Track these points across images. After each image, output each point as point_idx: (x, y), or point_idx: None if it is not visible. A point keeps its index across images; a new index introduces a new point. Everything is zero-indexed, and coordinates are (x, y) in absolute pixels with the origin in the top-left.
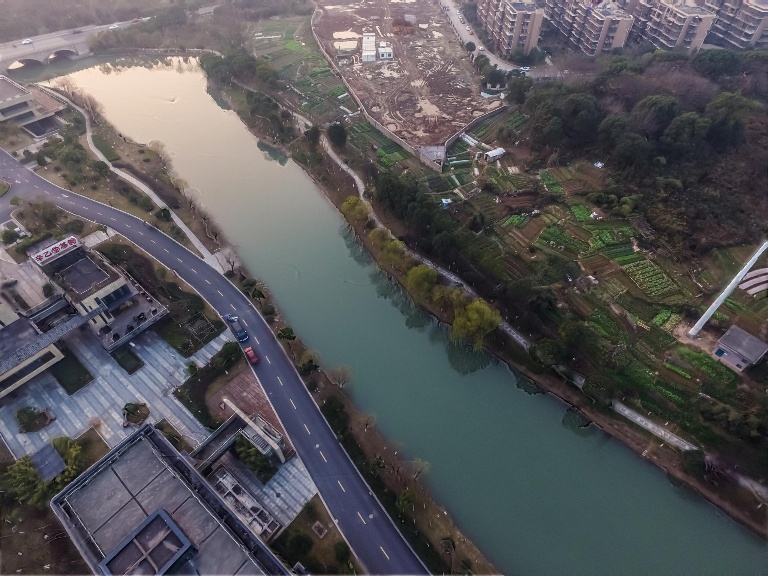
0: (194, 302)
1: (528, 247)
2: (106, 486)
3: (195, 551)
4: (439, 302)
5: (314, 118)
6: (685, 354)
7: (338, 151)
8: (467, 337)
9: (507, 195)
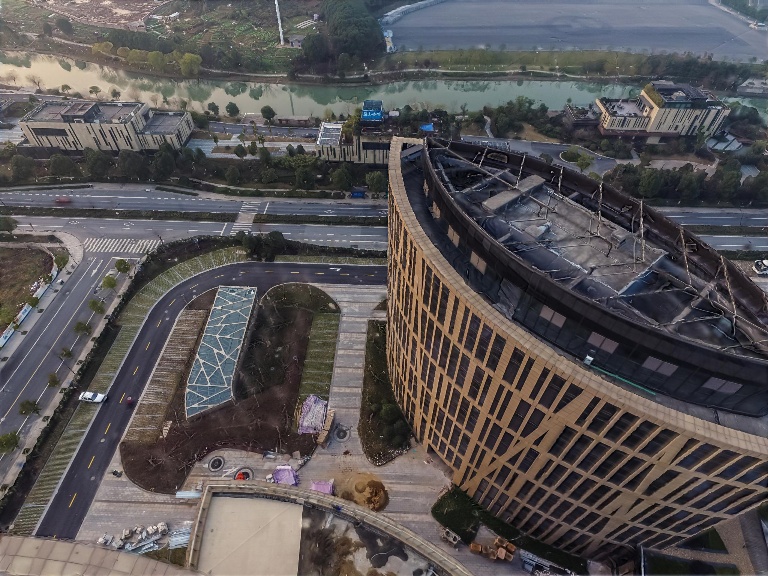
0: (25, 102)
1: (208, 43)
2: (42, 115)
3: (99, 110)
4: (172, 71)
5: (37, 31)
6: (281, 50)
7: (70, 39)
8: (189, 69)
9: (188, 29)
